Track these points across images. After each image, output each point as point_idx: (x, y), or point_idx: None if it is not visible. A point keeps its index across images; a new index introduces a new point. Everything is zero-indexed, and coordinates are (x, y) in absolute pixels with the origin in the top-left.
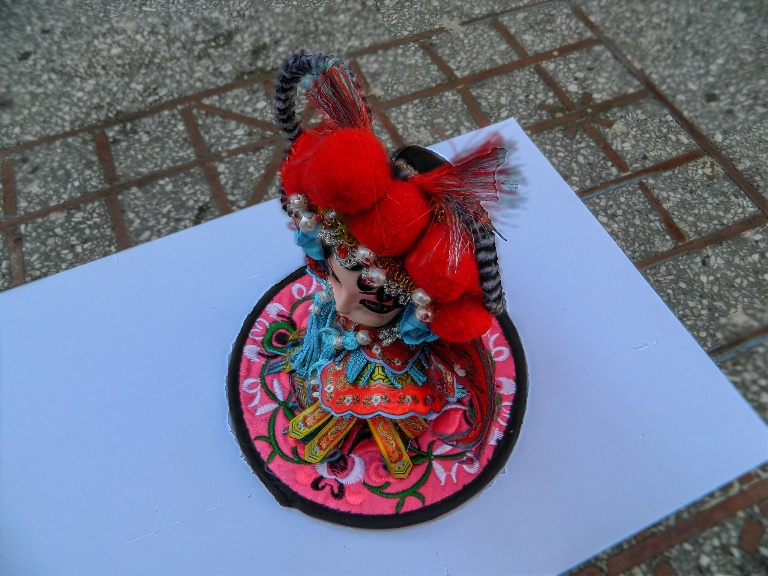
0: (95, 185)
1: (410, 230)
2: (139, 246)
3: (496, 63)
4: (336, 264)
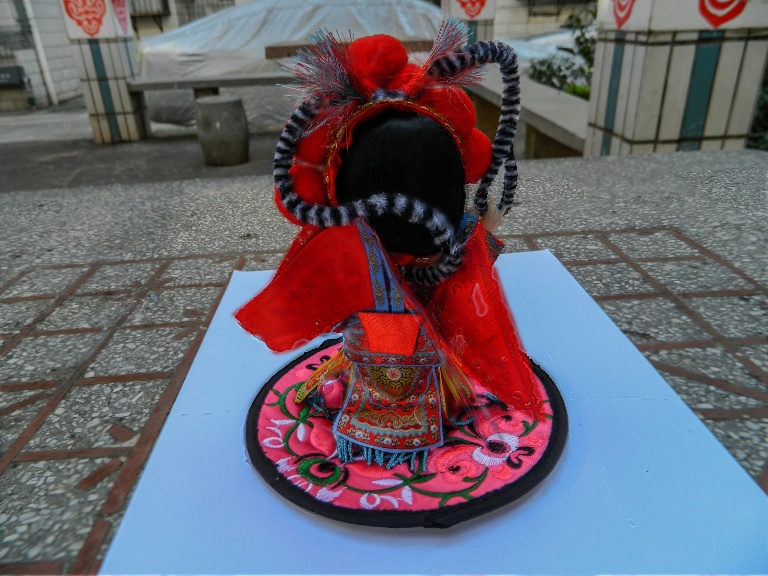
0: (676, 289)
1: None
2: (596, 304)
3: None
4: None
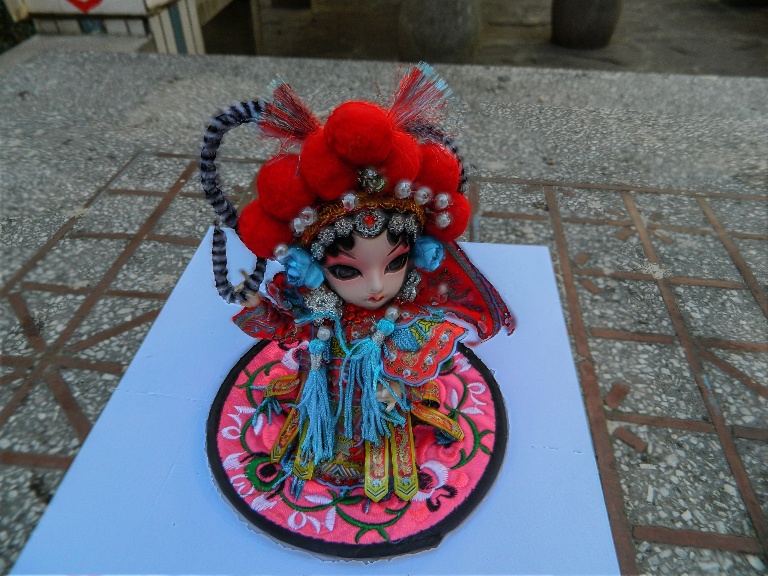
0: None
1: (416, 150)
2: None
3: (150, 210)
4: (360, 247)
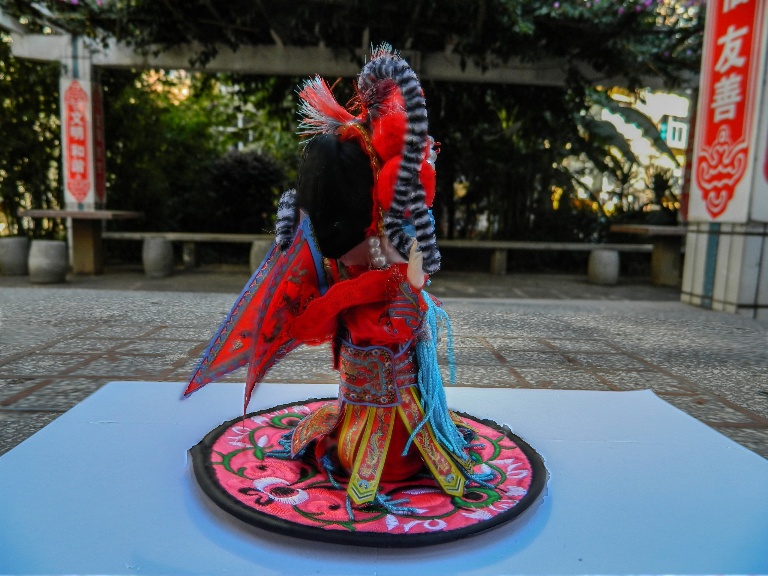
0: None
1: None
2: None
3: None
4: None
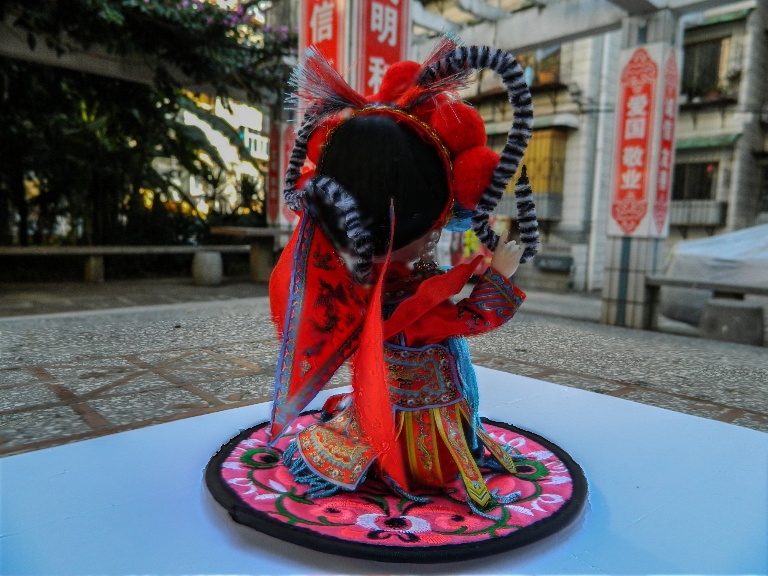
0: None
1: None
2: None
3: None
4: None
